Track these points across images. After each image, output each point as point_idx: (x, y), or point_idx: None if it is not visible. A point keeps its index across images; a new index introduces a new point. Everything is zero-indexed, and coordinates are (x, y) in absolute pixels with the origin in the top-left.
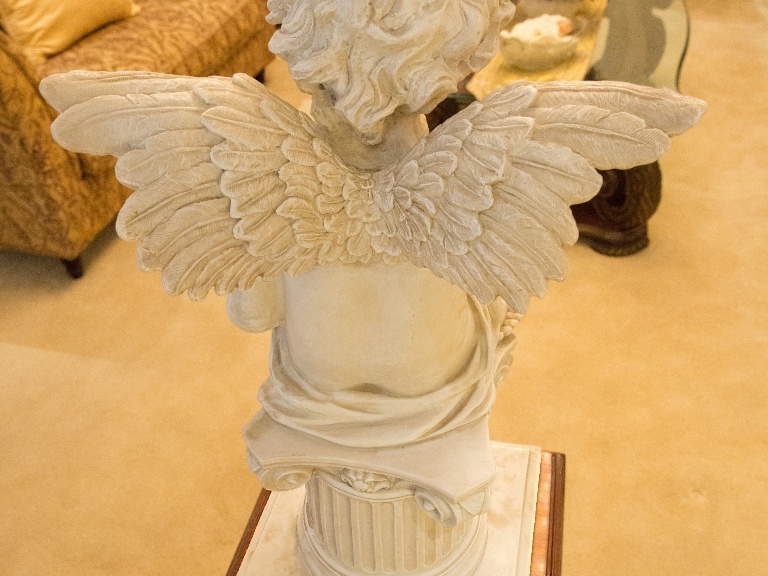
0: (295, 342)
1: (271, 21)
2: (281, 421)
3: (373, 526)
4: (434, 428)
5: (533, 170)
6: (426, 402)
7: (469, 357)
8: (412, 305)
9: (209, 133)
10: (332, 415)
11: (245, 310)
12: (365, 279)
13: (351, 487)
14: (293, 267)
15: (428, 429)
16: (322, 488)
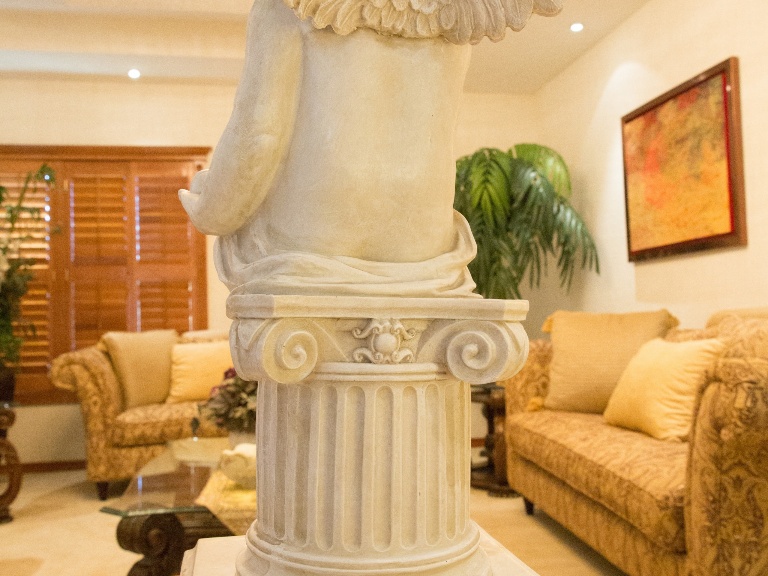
0: (306, 165)
1: None
2: (281, 280)
3: (393, 437)
4: (446, 288)
5: None
6: (431, 266)
7: (454, 240)
8: (432, 98)
9: None
10: (339, 272)
11: (258, 118)
12: (393, 61)
13: (369, 363)
14: (344, 9)
15: (442, 284)
16: (319, 405)
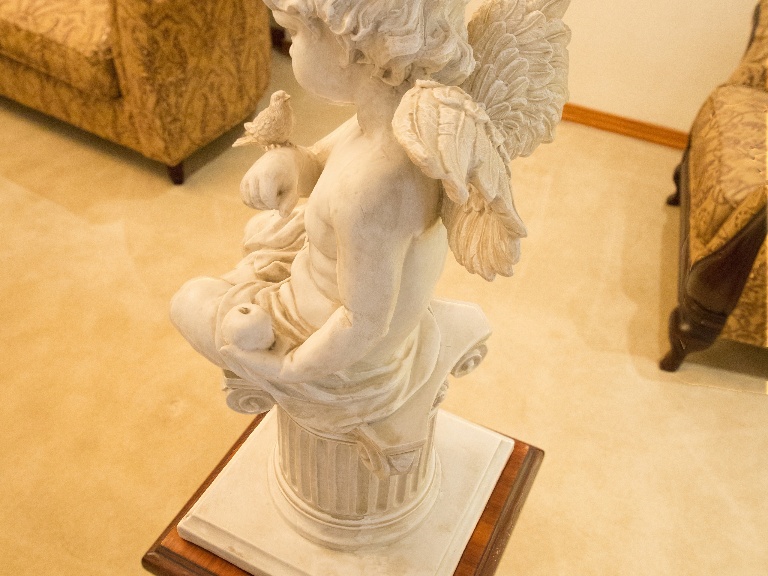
0: (401, 322)
1: (364, 37)
2: None
3: None
4: None
5: (555, 40)
6: None
7: None
8: None
9: (481, 125)
10: (408, 369)
11: None
12: None
13: None
14: None
15: None
16: None
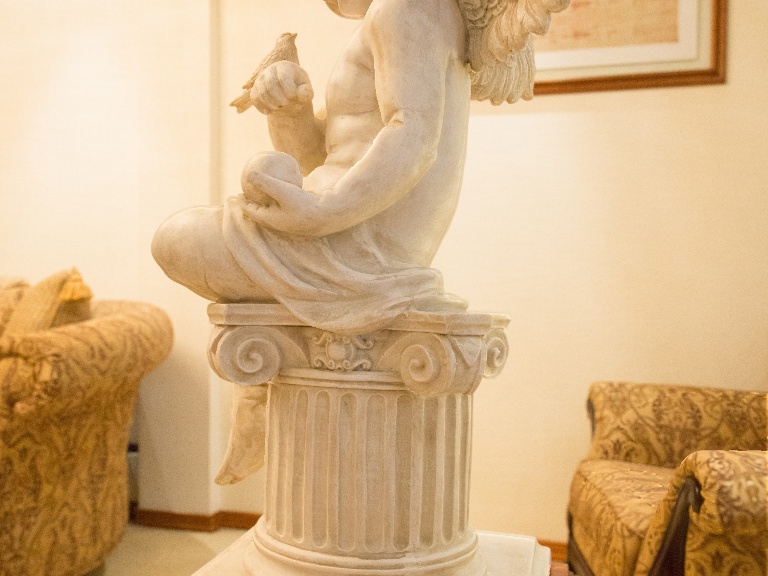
0: (440, 184)
1: None
2: (446, 296)
3: None
4: None
5: None
6: None
7: None
8: None
9: None
10: None
11: (439, 133)
12: None
13: None
14: None
15: None
16: None
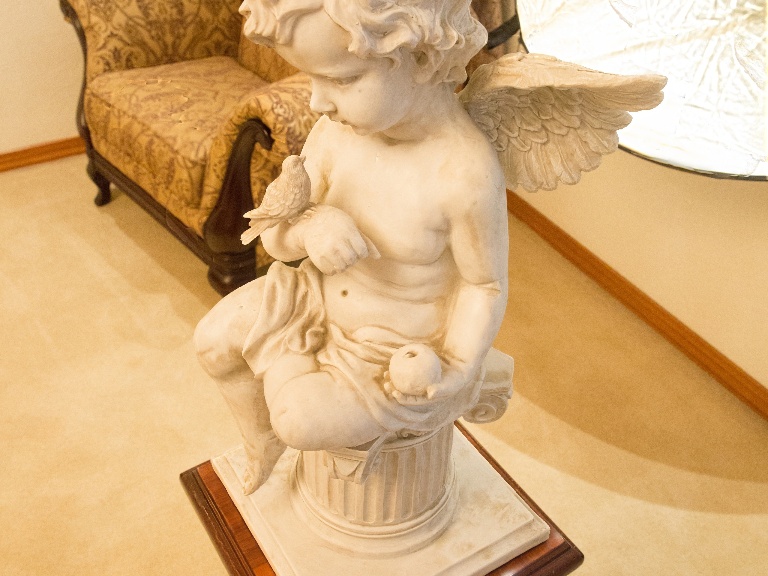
0: None
1: None
2: None
3: None
4: None
5: None
6: None
7: None
8: None
9: None
10: None
11: None
12: None
13: None
14: None
15: None
16: None
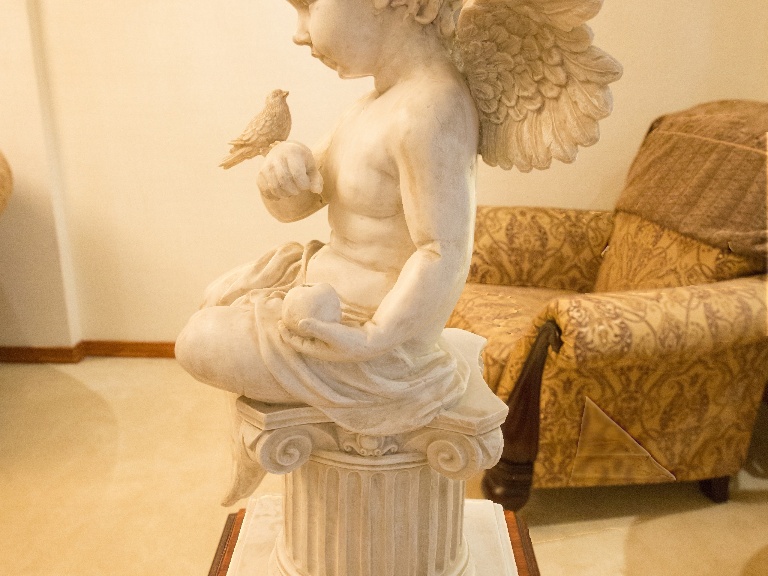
0: None
1: None
2: None
3: None
4: None
5: None
6: None
7: None
8: None
9: None
10: None
11: None
12: None
13: None
14: None
15: None
16: None
